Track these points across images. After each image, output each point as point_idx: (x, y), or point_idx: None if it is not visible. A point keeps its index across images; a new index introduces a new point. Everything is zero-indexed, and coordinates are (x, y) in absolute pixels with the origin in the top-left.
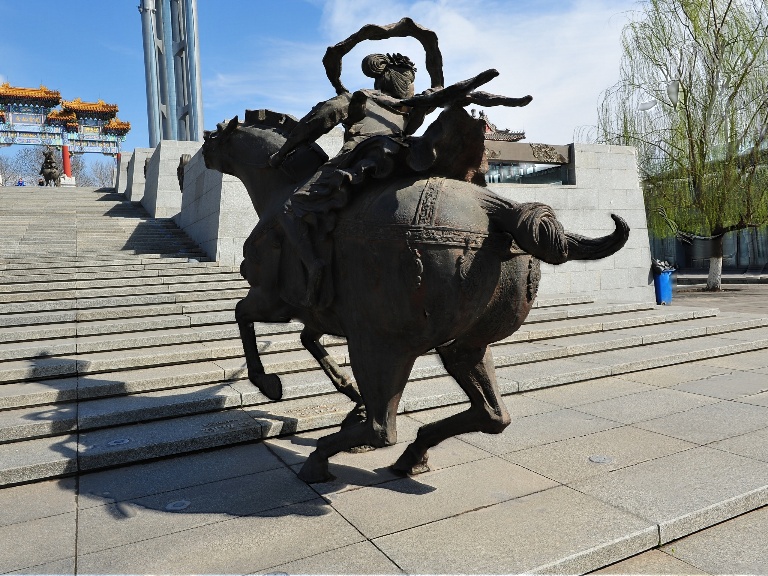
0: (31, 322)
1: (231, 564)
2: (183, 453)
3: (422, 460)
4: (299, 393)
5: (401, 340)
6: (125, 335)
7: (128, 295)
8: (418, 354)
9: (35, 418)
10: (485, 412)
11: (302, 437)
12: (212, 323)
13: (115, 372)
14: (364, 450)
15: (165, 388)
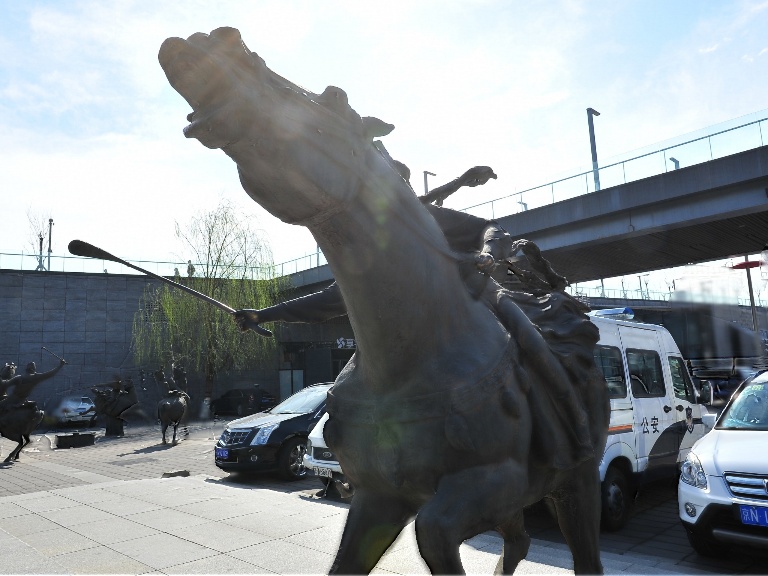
0: None
1: None
2: None
3: None
4: None
5: None
6: None
7: None
8: None
9: None
10: None
11: None
12: None
13: None
14: None
15: None
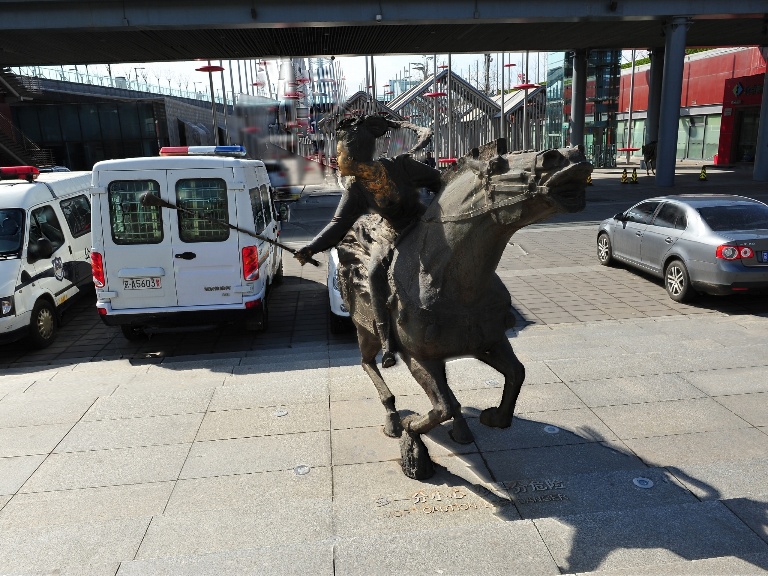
0: None
1: None
2: None
3: None
4: None
5: None
6: None
7: None
8: None
9: None
10: None
11: None
12: None
13: None
14: None
15: None
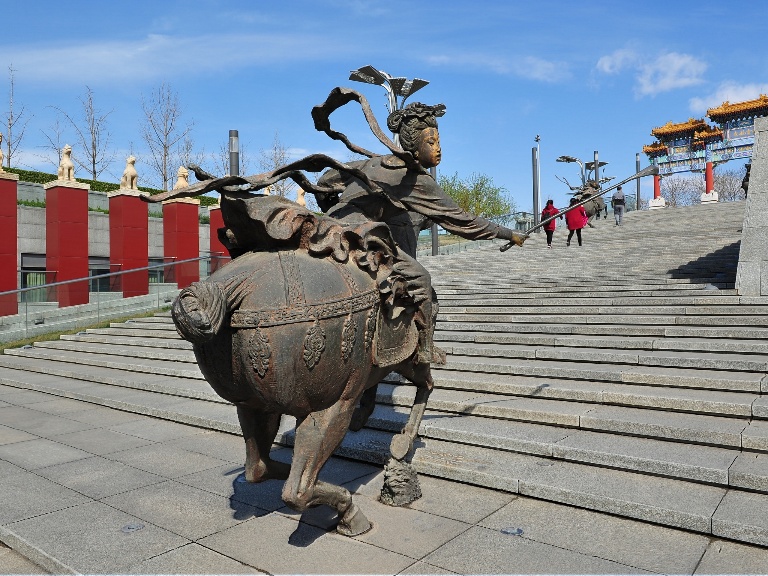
0: (447, 339)
1: (157, 513)
2: (335, 455)
3: (343, 522)
4: (473, 440)
5: None
6: None
7: None
8: None
9: None
10: None
11: None
12: (556, 359)
13: None
14: (388, 502)
15: None
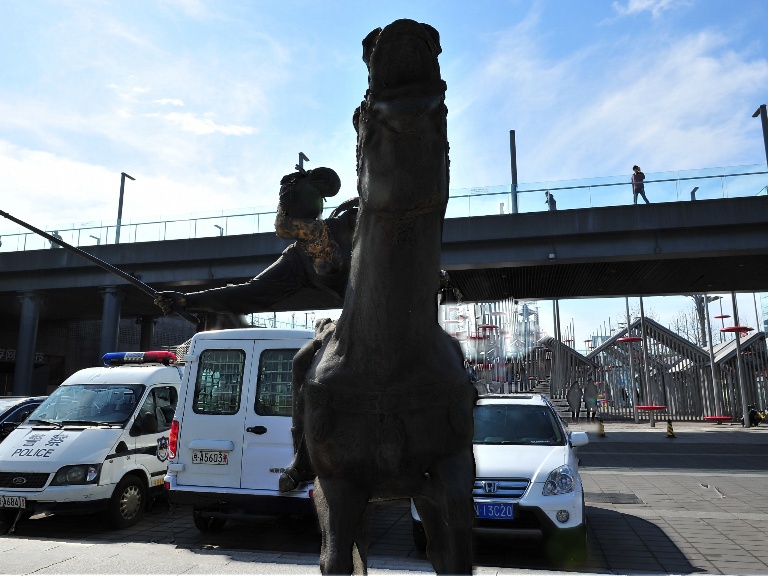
0: None
1: None
2: None
3: None
4: None
5: None
6: None
7: None
8: None
9: None
10: None
11: None
12: None
13: None
14: None
15: None
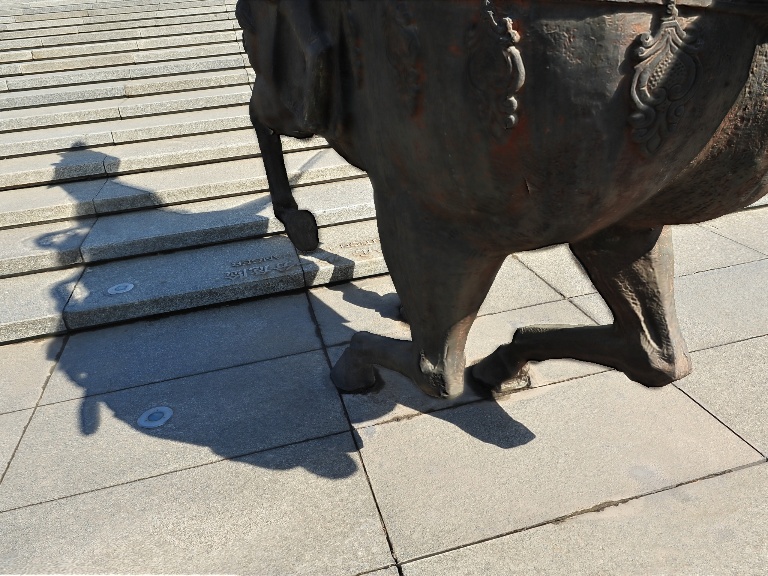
0: (75, 98)
1: None
2: (200, 307)
3: (518, 374)
4: (367, 213)
5: (473, 227)
6: (173, 117)
7: (193, 57)
8: (510, 252)
9: (35, 245)
10: (640, 351)
11: (360, 288)
12: None
13: (152, 172)
14: None
15: (202, 199)
